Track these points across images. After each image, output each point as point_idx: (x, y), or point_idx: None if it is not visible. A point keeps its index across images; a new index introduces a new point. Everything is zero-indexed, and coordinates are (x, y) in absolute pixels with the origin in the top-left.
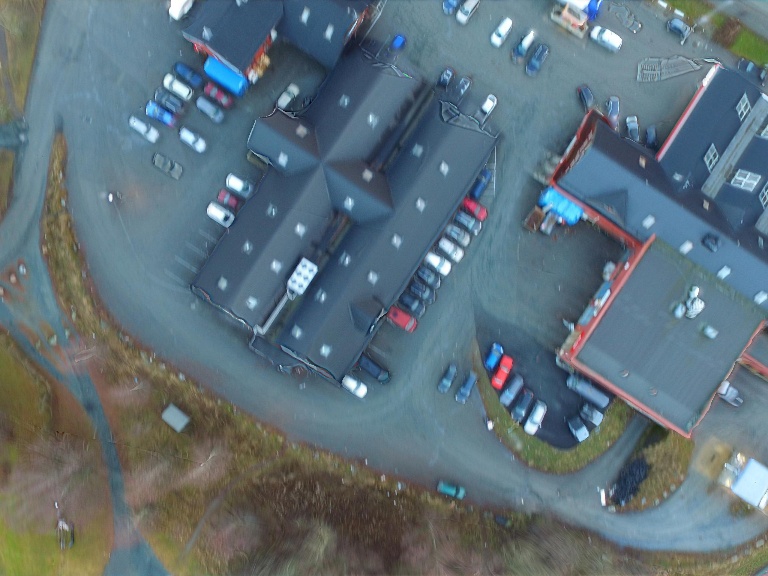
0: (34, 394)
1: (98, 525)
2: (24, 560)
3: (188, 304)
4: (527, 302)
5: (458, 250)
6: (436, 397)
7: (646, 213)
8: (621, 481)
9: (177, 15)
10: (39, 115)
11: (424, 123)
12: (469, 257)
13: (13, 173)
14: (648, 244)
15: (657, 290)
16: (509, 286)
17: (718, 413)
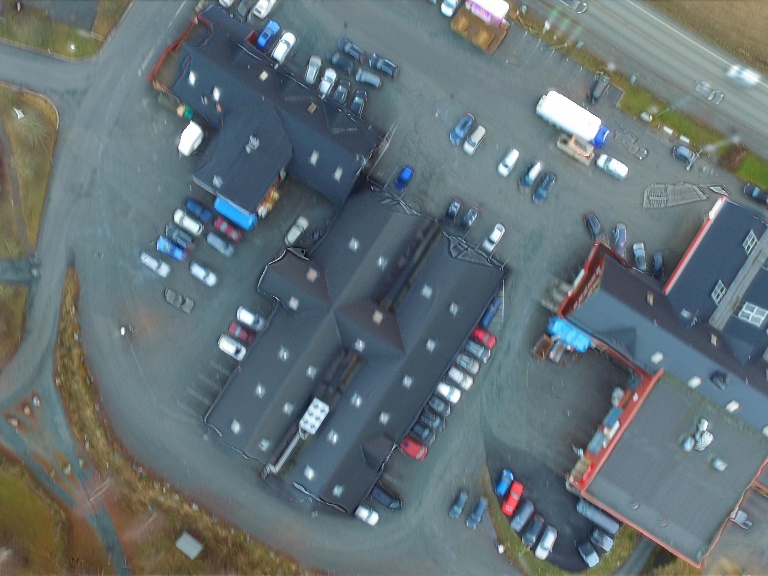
0: (49, 522)
1: None
2: None
3: (200, 435)
4: (536, 428)
5: (467, 378)
6: (447, 522)
7: (654, 350)
8: None
9: (187, 152)
10: (51, 250)
11: (433, 261)
12: (478, 384)
13: (26, 307)
14: (656, 378)
15: (666, 423)
16: (518, 412)
17: (727, 534)
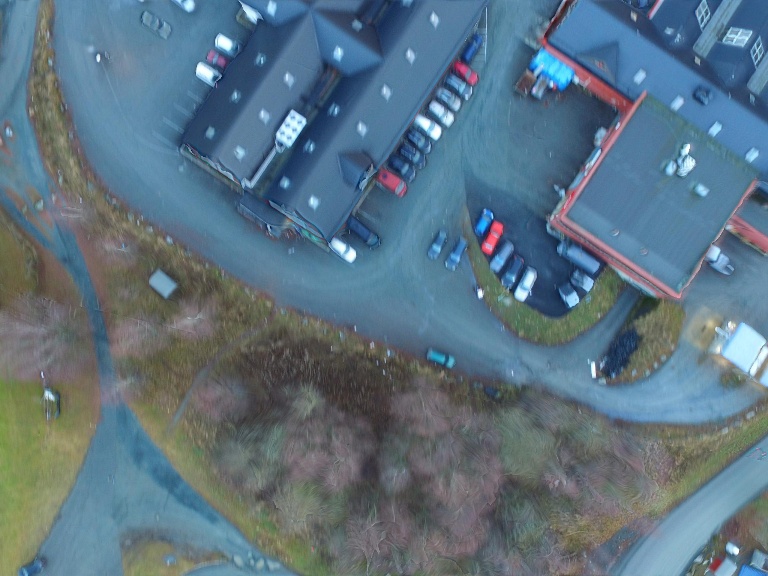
0: (20, 260)
1: (84, 395)
2: (9, 431)
3: (176, 166)
4: (518, 168)
5: (449, 114)
6: (426, 264)
7: (637, 67)
8: (612, 353)
9: None
10: None
11: None
12: (460, 123)
13: None
14: (639, 101)
15: (648, 148)
16: (500, 152)
17: (709, 283)
